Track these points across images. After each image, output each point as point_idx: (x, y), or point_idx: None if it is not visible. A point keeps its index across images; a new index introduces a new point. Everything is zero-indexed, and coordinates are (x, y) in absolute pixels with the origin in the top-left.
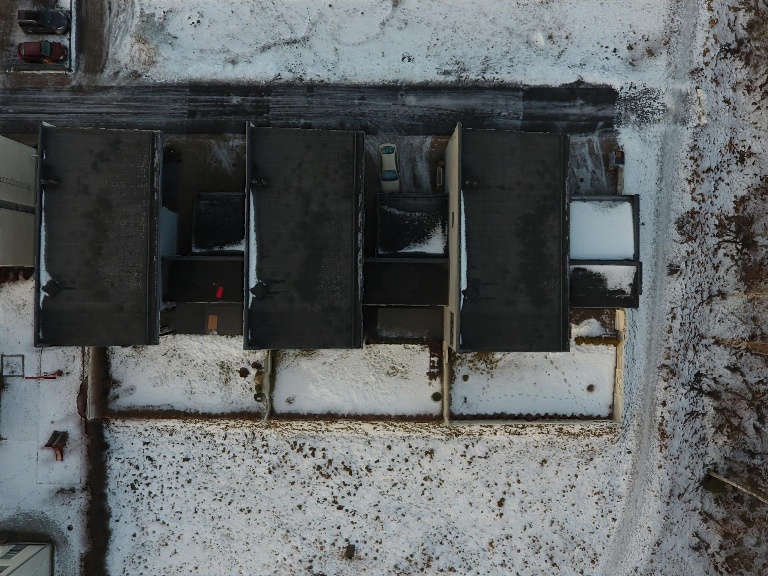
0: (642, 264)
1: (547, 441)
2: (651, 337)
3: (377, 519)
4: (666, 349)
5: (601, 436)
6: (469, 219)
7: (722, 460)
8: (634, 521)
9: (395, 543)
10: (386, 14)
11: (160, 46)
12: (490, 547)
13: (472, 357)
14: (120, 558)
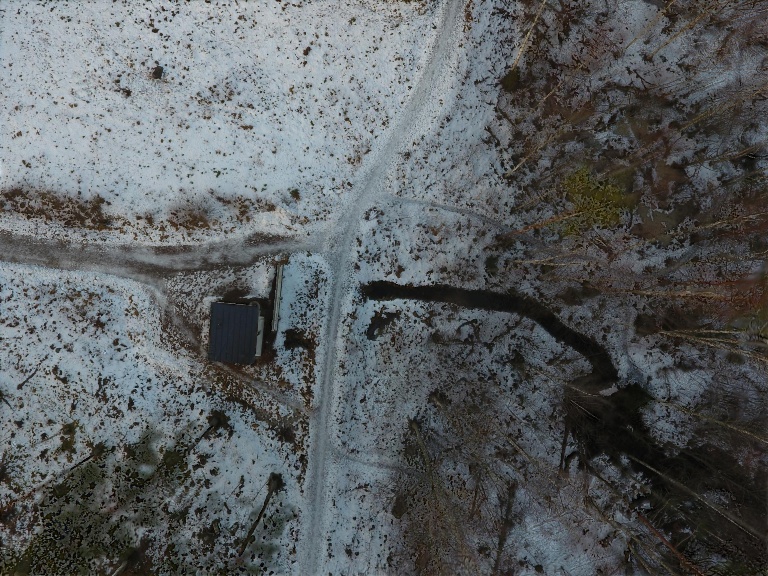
0: None
1: (359, 0)
2: None
3: (188, 47)
4: None
5: (409, 2)
6: None
7: (524, 64)
8: (428, 91)
9: (201, 73)
10: None
11: None
12: (290, 92)
13: None
14: None
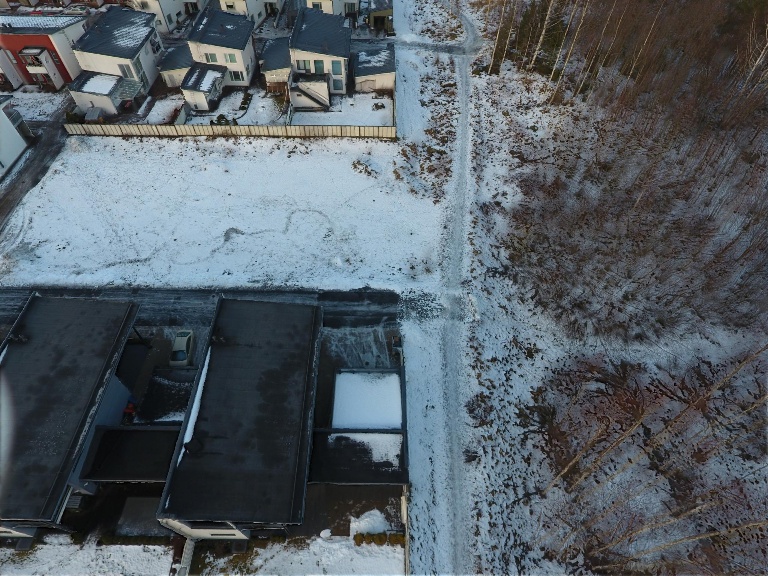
0: (407, 431)
1: None
2: (455, 541)
3: None
4: (475, 558)
5: None
6: (211, 372)
7: None
8: None
9: None
10: (218, 245)
11: (21, 261)
12: None
13: (225, 564)
14: None
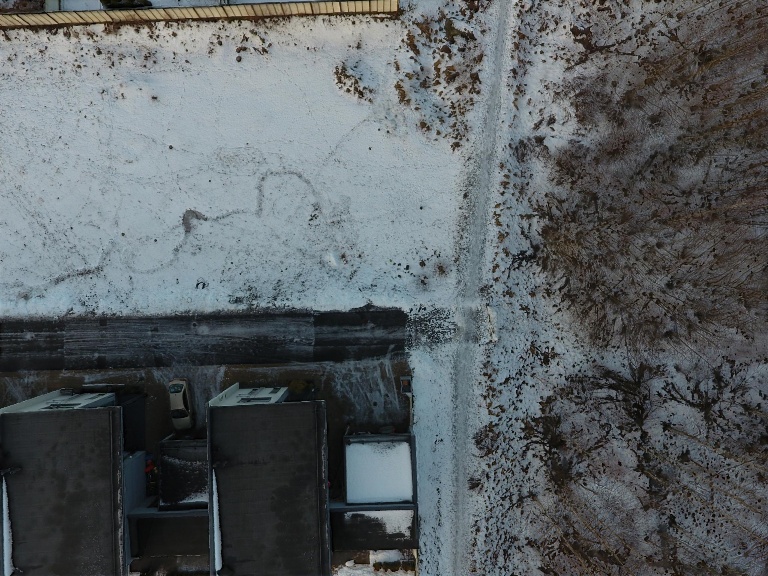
0: (418, 509)
1: None
2: (456, 551)
3: None
4: (472, 562)
5: None
6: (222, 498)
7: None
8: None
9: None
10: (179, 240)
11: None
12: None
13: None
14: None
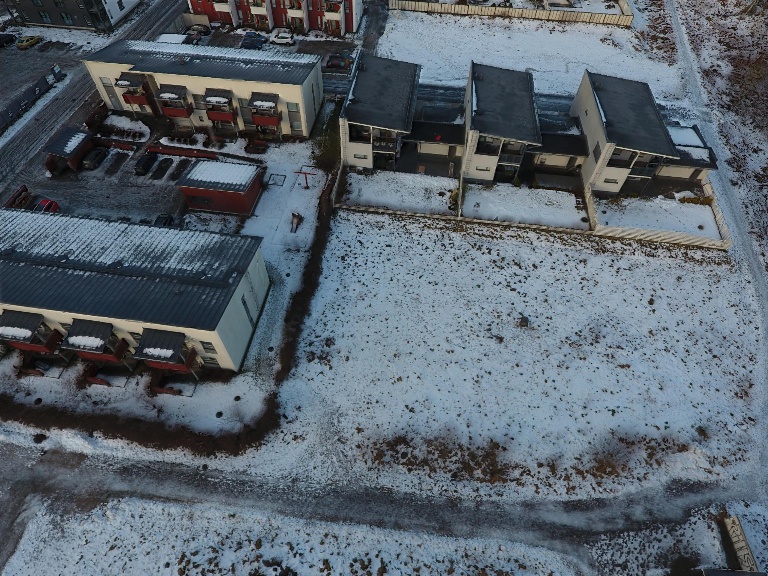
0: (711, 148)
1: (677, 265)
2: (734, 215)
3: (545, 302)
4: (749, 223)
5: (720, 265)
6: (600, 99)
7: None
8: None
9: (564, 321)
10: None
11: None
12: (650, 335)
13: (606, 202)
14: (322, 303)
